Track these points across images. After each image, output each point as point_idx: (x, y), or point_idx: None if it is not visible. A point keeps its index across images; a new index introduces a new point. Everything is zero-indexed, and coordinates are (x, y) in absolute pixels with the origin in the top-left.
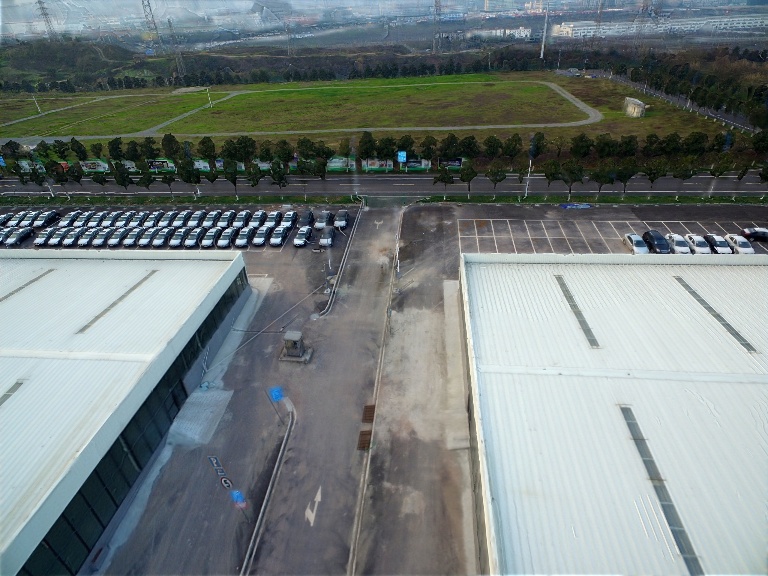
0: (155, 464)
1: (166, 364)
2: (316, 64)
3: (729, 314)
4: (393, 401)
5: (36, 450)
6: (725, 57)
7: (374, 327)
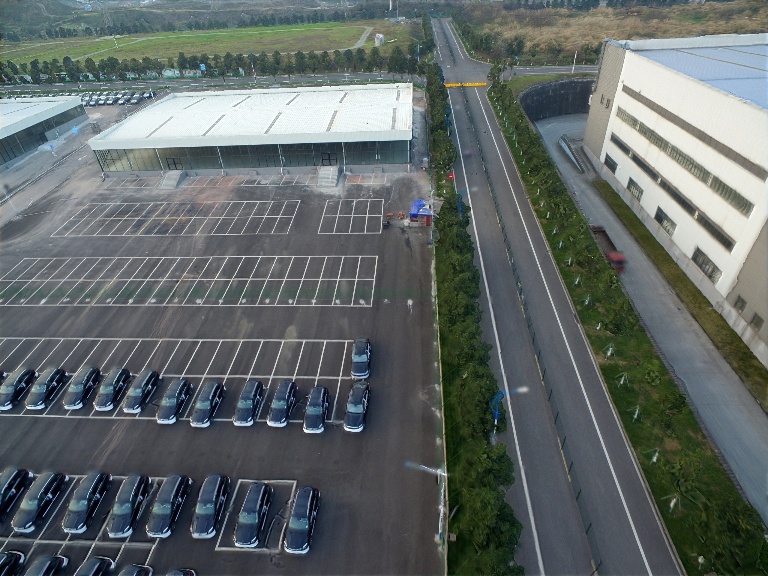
0: None
1: (35, 122)
2: (233, 17)
3: None
4: None
5: None
6: (500, 7)
7: None
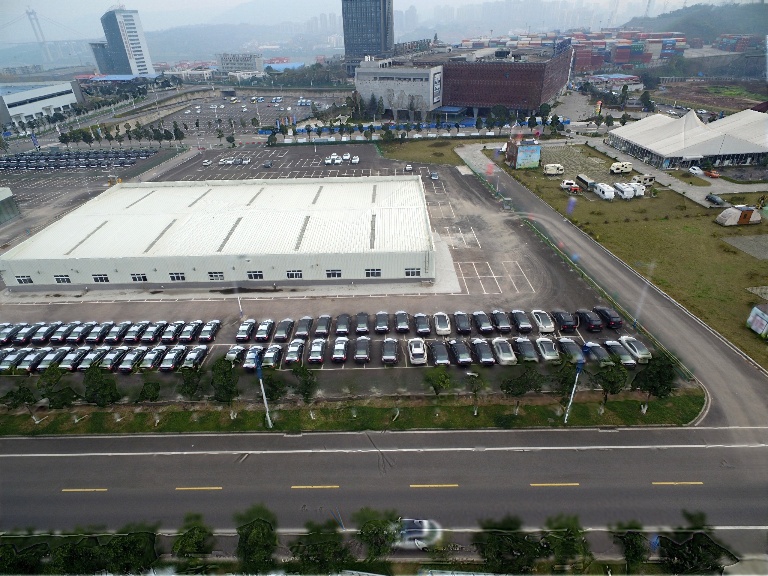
0: None
1: None
2: None
3: None
4: None
5: None
6: None
7: None
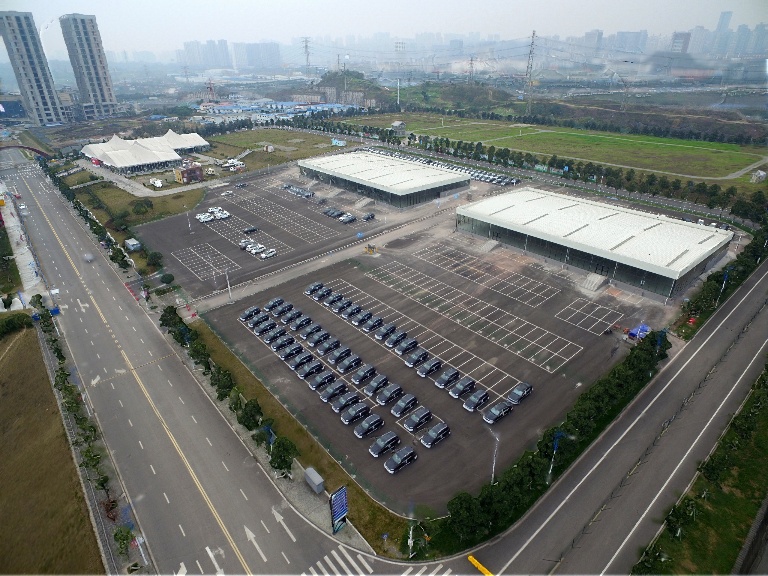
0: None
1: (439, 185)
2: (636, 119)
3: None
4: None
5: (413, 185)
6: None
7: None
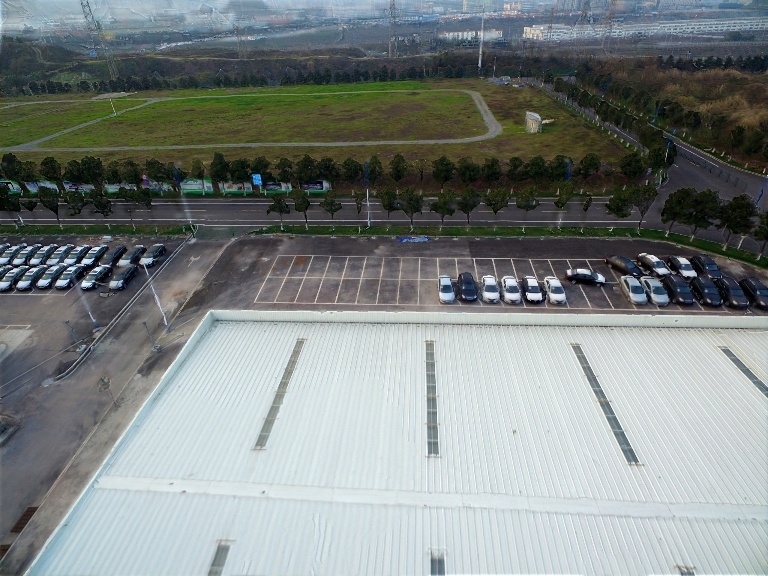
0: None
1: None
2: (265, 67)
3: (447, 397)
4: (61, 501)
5: None
6: (653, 67)
7: (106, 396)
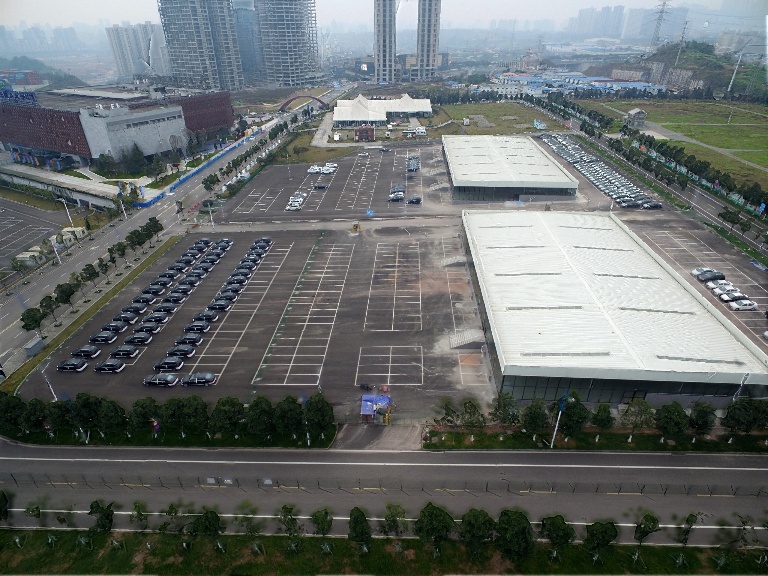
0: (497, 203)
1: (517, 186)
2: None
3: None
4: None
5: None
6: None
7: None
